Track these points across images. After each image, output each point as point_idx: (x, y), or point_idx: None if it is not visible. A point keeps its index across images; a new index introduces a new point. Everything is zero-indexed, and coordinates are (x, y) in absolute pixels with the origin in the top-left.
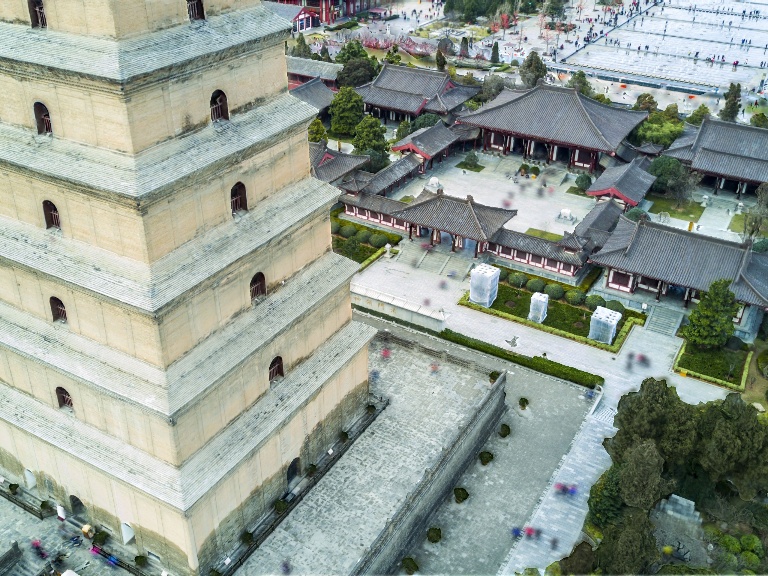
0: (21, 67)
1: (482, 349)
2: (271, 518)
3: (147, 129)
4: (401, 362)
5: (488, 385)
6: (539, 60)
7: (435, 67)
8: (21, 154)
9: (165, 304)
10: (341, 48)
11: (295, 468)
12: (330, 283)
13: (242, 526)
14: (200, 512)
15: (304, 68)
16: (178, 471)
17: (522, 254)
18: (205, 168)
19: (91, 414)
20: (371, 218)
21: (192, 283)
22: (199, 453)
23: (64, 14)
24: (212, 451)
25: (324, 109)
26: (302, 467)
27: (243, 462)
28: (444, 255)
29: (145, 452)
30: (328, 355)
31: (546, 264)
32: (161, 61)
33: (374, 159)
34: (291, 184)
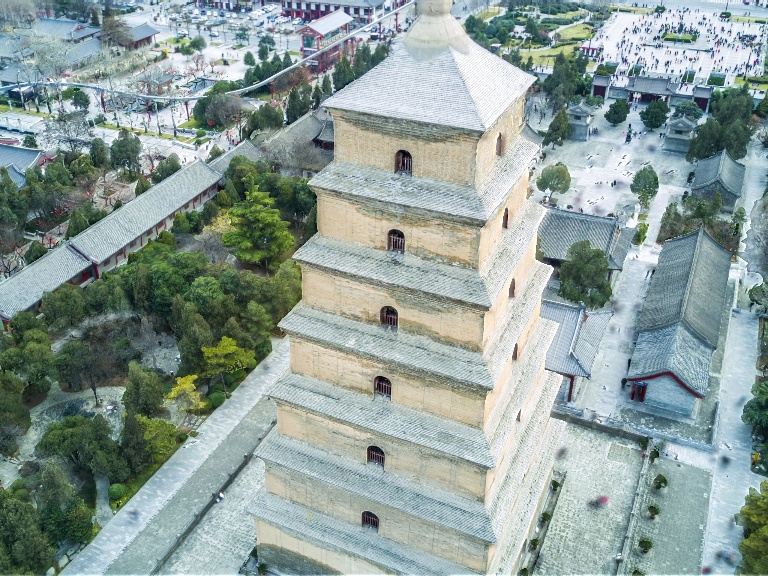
0: None
1: None
2: None
3: None
4: None
5: None
6: None
7: None
8: None
9: None
10: None
11: None
12: None
13: None
14: None
15: None
16: None
17: None
18: None
19: None
20: None
21: None
22: None
23: None
24: None
25: None
26: None
27: None
28: None
29: None
30: None
31: None
32: None
33: None
34: None
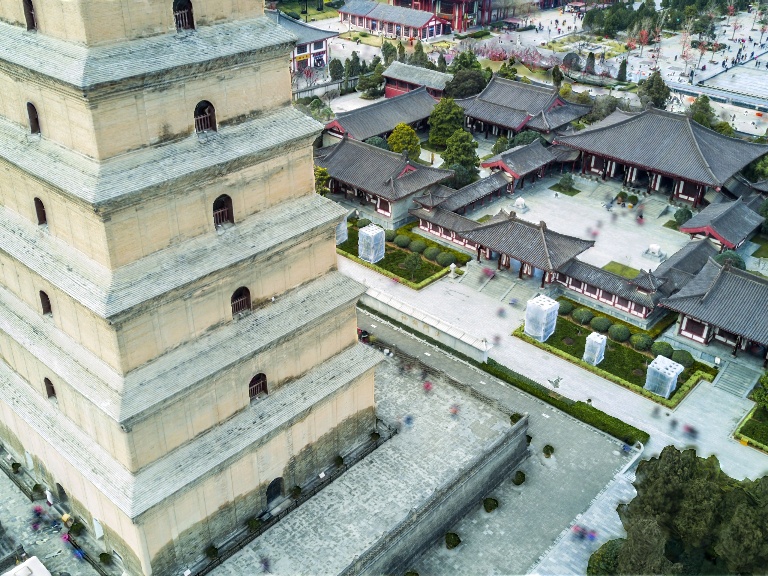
0: (13, 68)
1: (520, 386)
2: (243, 535)
3: (116, 136)
4: (423, 390)
5: (508, 427)
6: (661, 81)
7: (551, 82)
8: (13, 151)
9: (121, 311)
10: (454, 58)
11: (279, 487)
12: (328, 304)
13: (208, 539)
14: (155, 521)
15: (414, 76)
16: (133, 477)
17: (592, 289)
18: (179, 179)
19: (69, 408)
20: (444, 235)
21: (154, 293)
22: (159, 462)
23: (49, 19)
24: (174, 461)
25: (424, 119)
26: (286, 487)
27: (209, 476)
28: (510, 281)
29: (109, 453)
30: (323, 377)
31: (617, 302)
32: (132, 70)
33: (459, 174)
34: (290, 200)
